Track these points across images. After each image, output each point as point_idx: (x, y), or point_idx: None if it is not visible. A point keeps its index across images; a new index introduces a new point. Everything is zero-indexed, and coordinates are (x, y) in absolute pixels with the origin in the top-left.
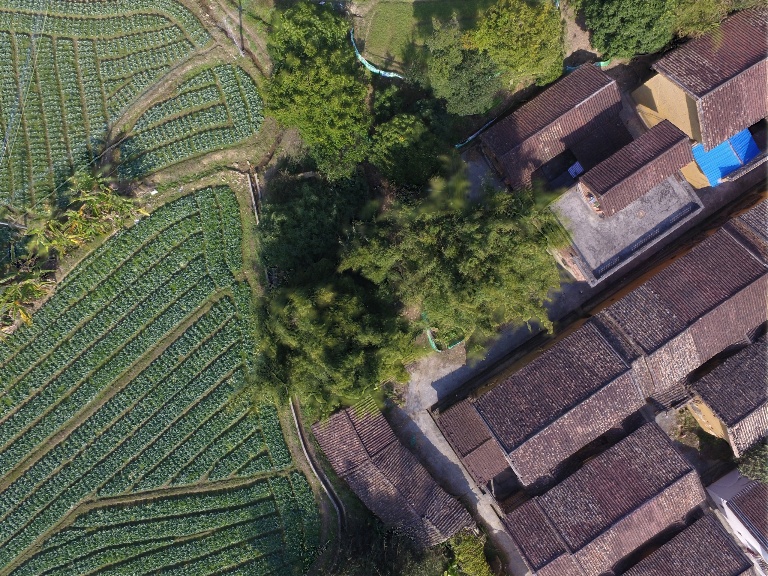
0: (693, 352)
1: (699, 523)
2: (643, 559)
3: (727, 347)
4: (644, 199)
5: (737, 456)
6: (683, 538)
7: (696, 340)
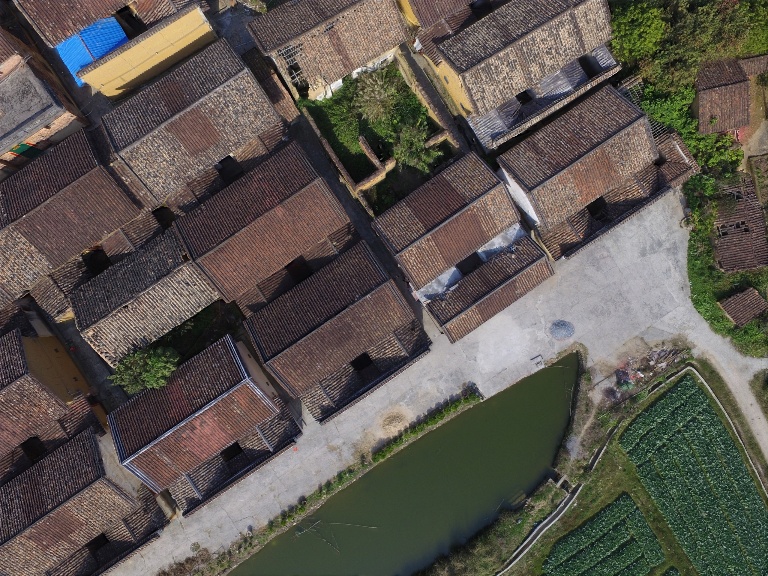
0: (35, 253)
1: (78, 437)
2: (20, 474)
3: (120, 256)
4: (4, 99)
5: (112, 366)
6: (60, 452)
7: (32, 240)
